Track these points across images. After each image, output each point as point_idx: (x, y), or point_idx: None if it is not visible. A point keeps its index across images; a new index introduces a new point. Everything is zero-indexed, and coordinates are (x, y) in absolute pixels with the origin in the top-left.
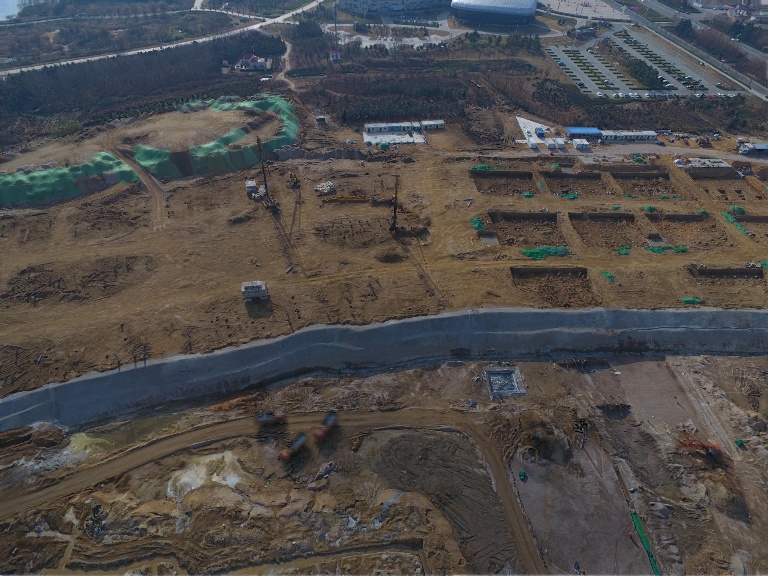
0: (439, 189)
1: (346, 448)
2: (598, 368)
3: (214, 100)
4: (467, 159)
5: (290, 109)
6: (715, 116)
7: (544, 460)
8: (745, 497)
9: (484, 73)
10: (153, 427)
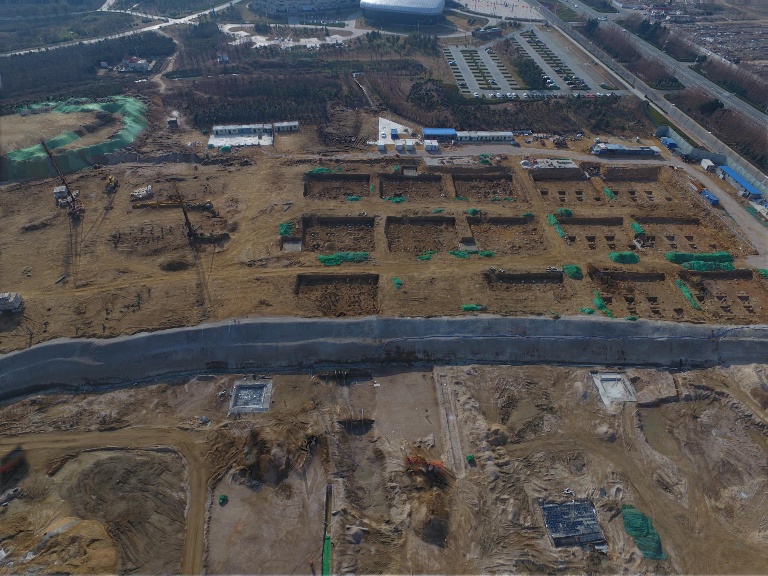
0: (263, 193)
1: (42, 472)
2: (359, 380)
3: (61, 102)
4: (308, 162)
5: (141, 111)
6: (584, 116)
7: (254, 481)
8: (450, 518)
9: (367, 73)
10: None
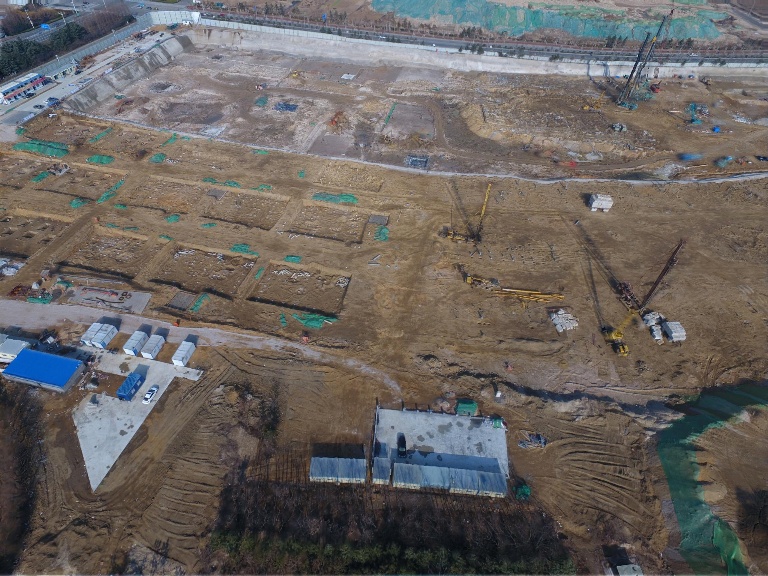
0: (403, 288)
1: None
2: None
3: None
4: (326, 346)
5: None
6: None
7: None
8: None
9: None
10: (627, 176)
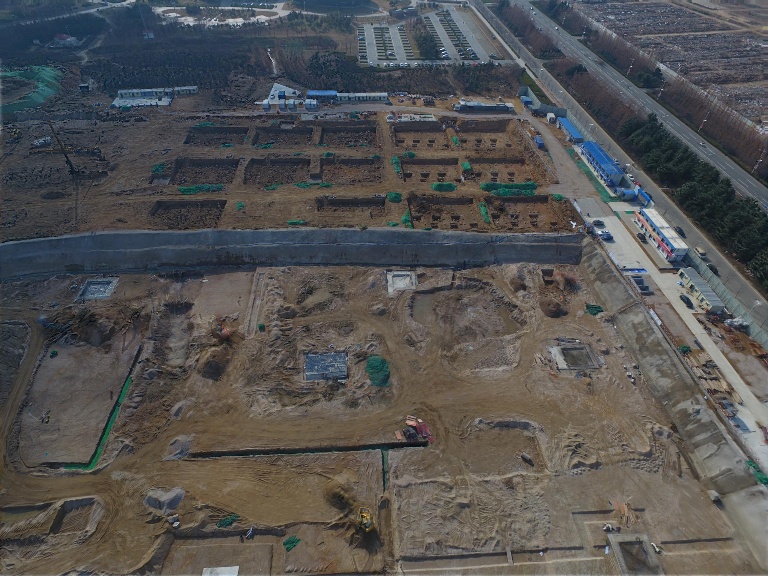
0: (148, 142)
1: None
2: (193, 278)
3: None
4: (197, 118)
5: (56, 78)
6: (461, 80)
7: (82, 343)
8: (230, 363)
9: None
10: None
